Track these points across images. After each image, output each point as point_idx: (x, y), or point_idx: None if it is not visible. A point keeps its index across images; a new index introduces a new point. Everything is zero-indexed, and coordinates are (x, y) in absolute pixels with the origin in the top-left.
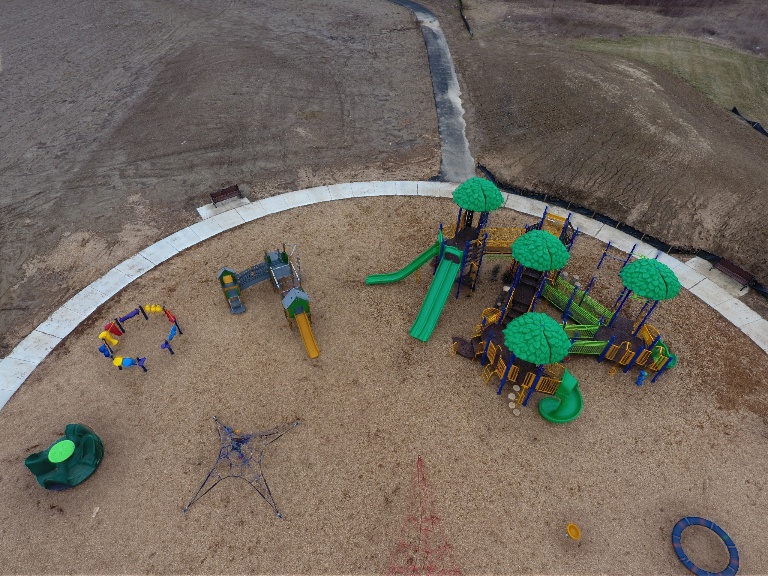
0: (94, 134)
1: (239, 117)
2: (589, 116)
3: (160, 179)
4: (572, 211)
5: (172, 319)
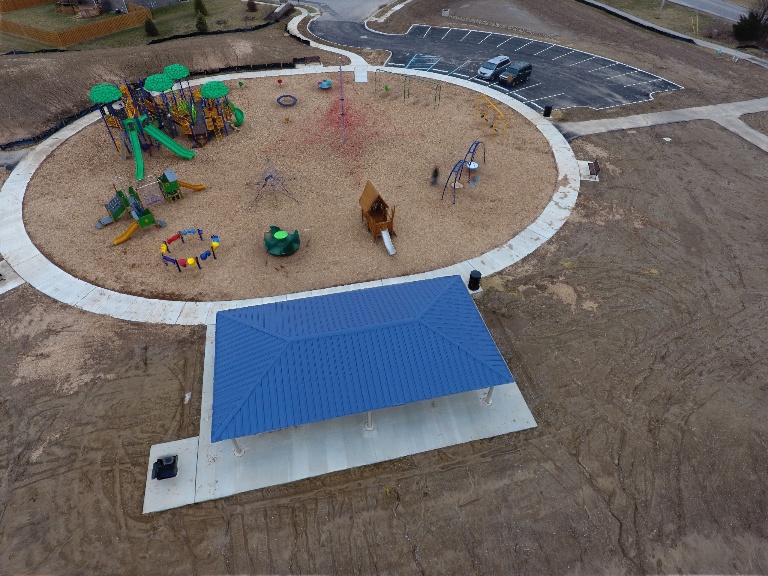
0: None
1: None
2: None
3: None
4: (81, 117)
5: (177, 234)
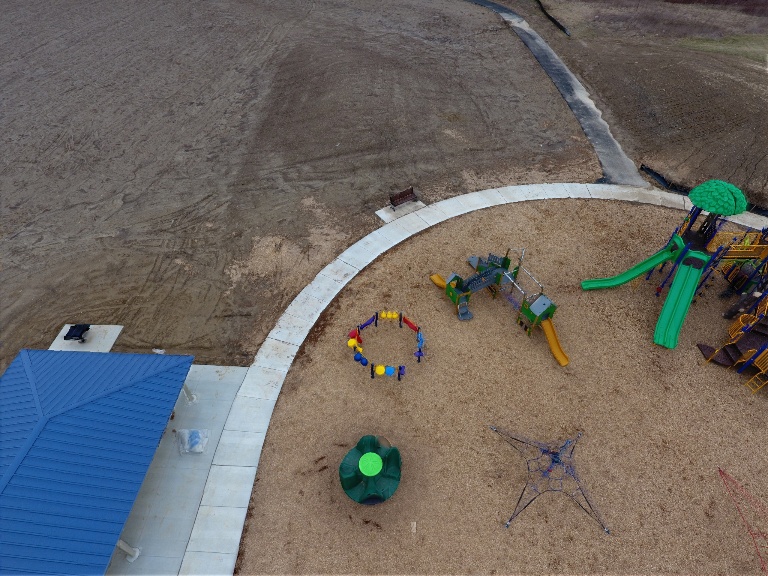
0: (236, 136)
1: (385, 119)
2: (748, 117)
3: (326, 182)
4: (756, 214)
5: (415, 326)
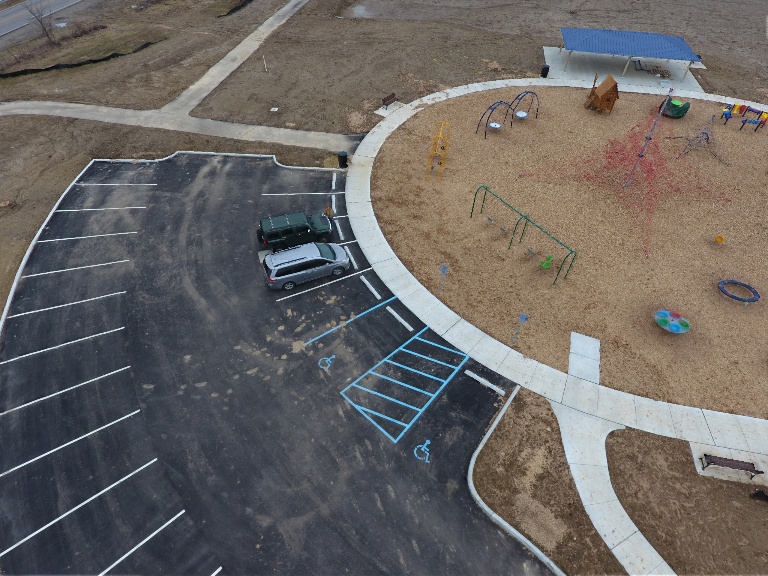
0: None
1: None
2: None
3: None
4: None
5: None
